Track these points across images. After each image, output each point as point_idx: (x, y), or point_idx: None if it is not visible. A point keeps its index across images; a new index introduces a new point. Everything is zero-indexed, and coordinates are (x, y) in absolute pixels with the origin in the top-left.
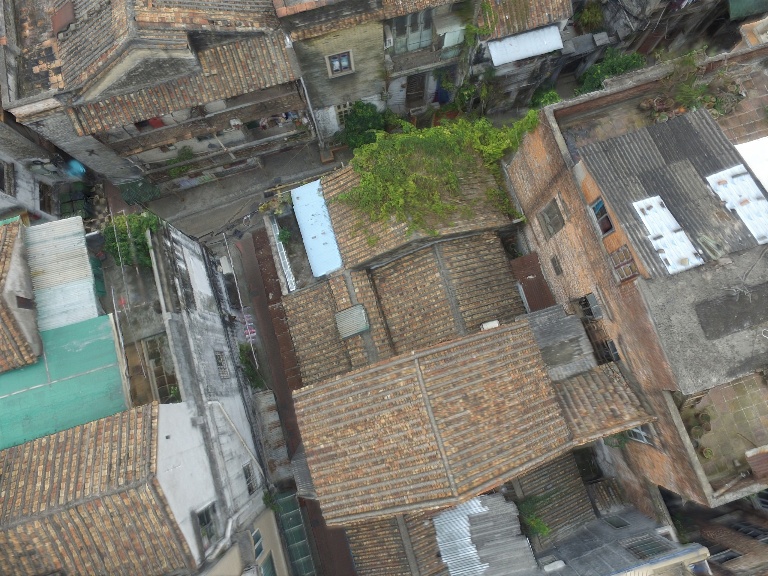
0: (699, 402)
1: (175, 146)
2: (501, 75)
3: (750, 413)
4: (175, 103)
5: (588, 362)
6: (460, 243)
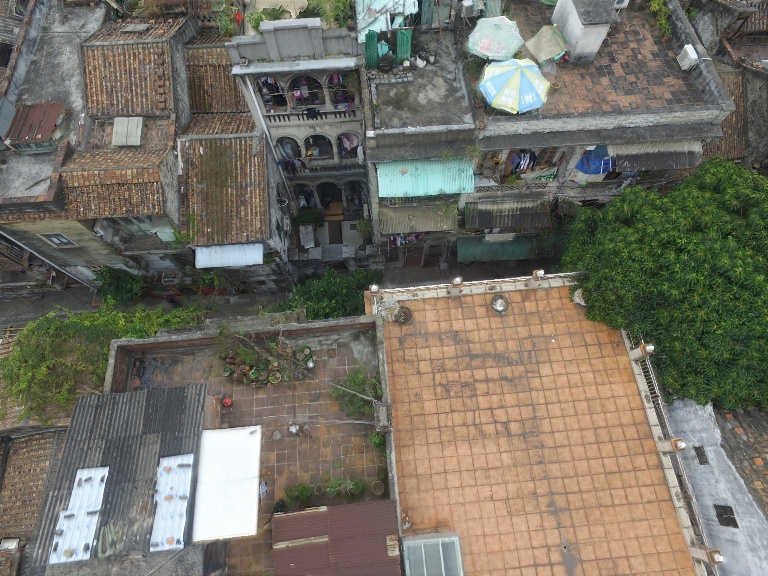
0: None
1: None
2: (237, 269)
3: None
4: None
5: None
6: None
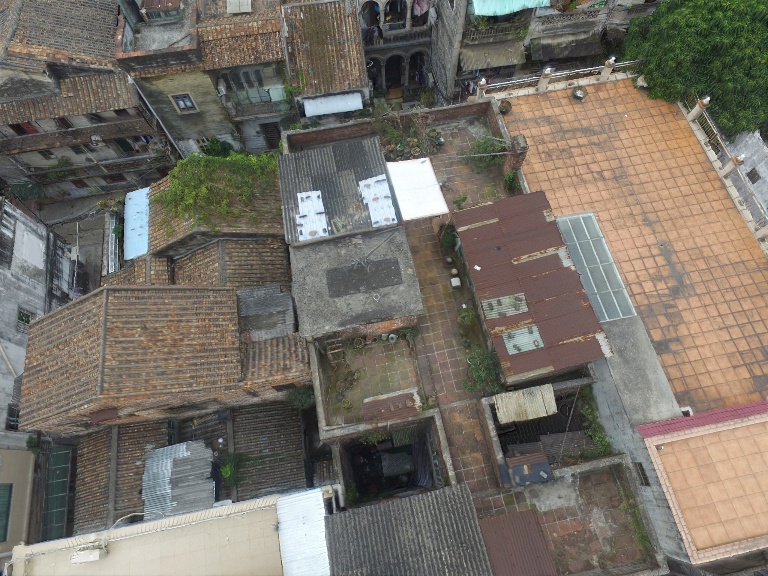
0: (344, 359)
1: (56, 155)
2: None
3: (393, 377)
4: (37, 114)
5: (286, 330)
6: (245, 244)
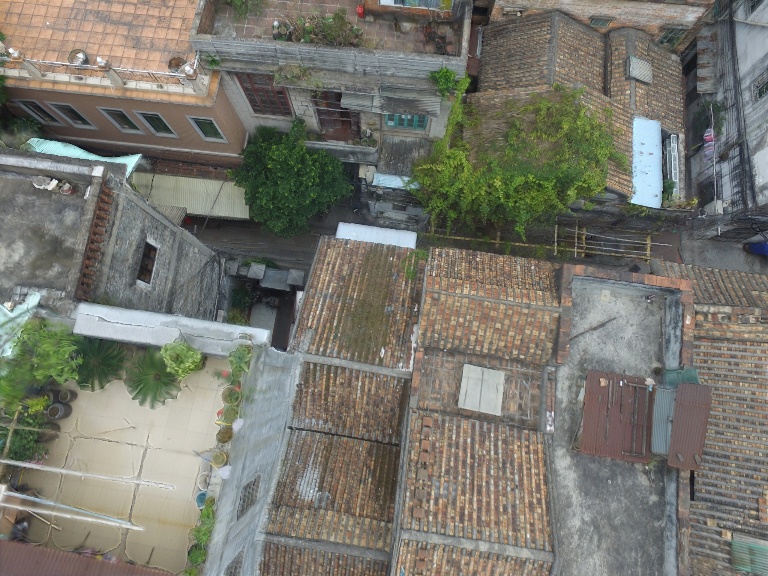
0: None
1: None
2: None
3: None
4: None
5: None
6: None
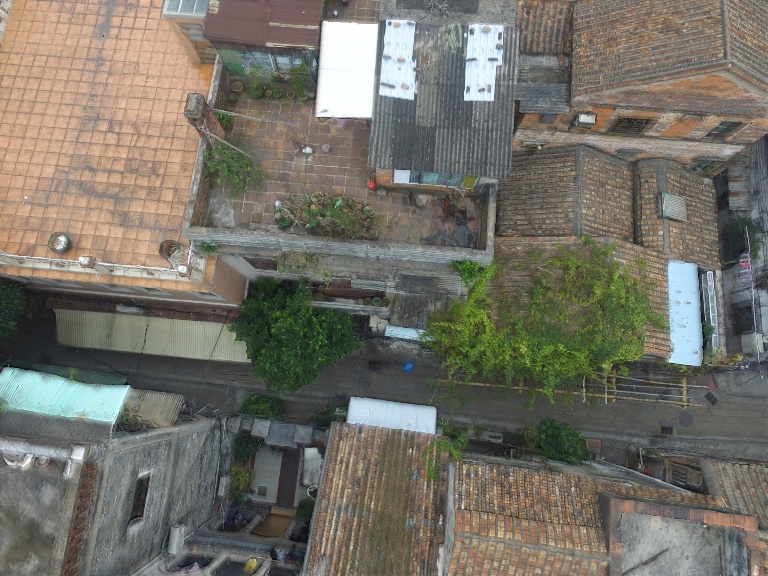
0: None
1: None
2: None
3: None
4: None
5: (520, 61)
6: (548, 235)
